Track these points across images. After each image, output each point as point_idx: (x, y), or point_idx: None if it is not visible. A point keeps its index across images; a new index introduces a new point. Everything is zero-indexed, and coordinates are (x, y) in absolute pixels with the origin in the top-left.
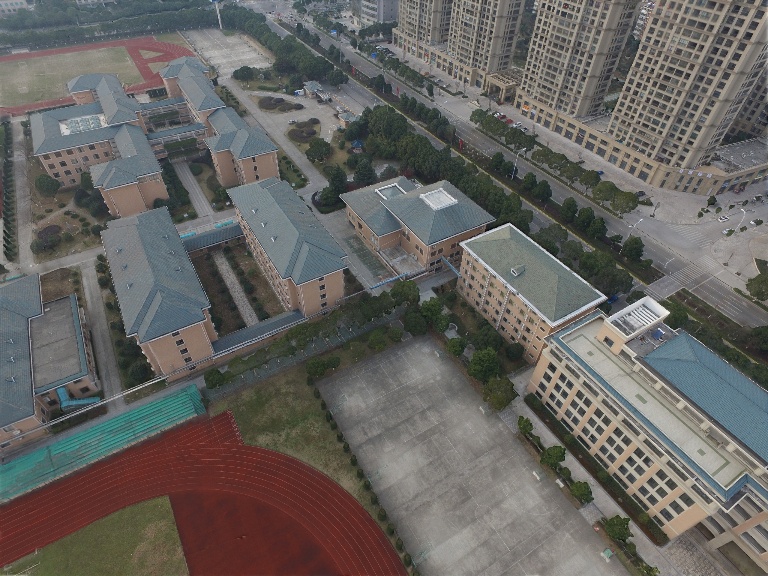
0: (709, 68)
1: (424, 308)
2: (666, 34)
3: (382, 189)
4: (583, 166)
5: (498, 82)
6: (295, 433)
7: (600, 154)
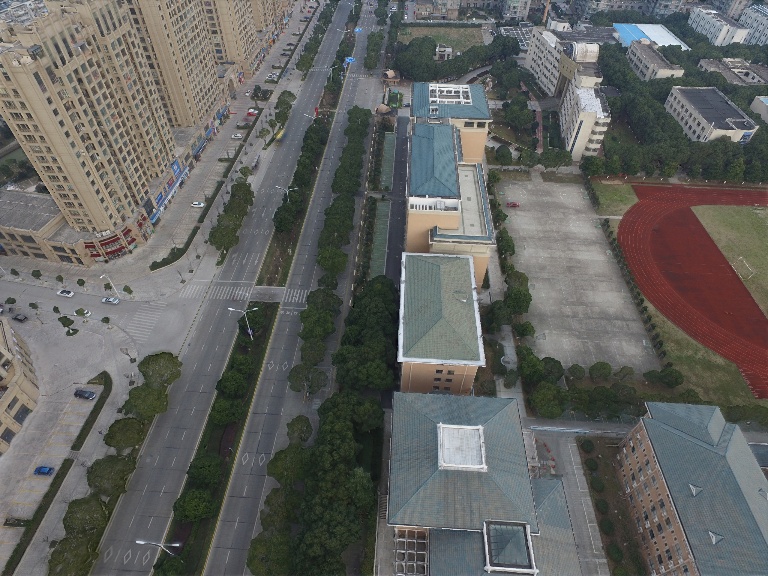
0: None
1: (542, 366)
2: None
3: (522, 570)
4: (28, 511)
5: None
6: (689, 352)
7: None
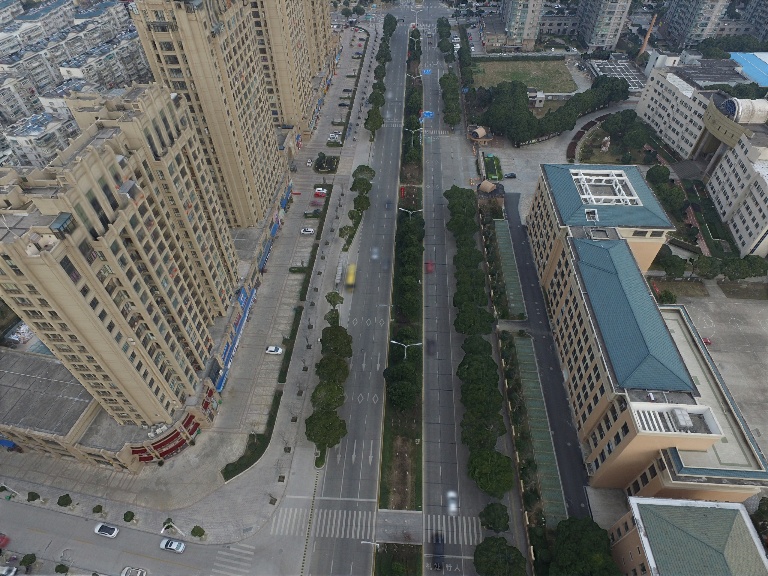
0: None
1: None
2: None
3: None
4: None
5: None
6: None
7: None
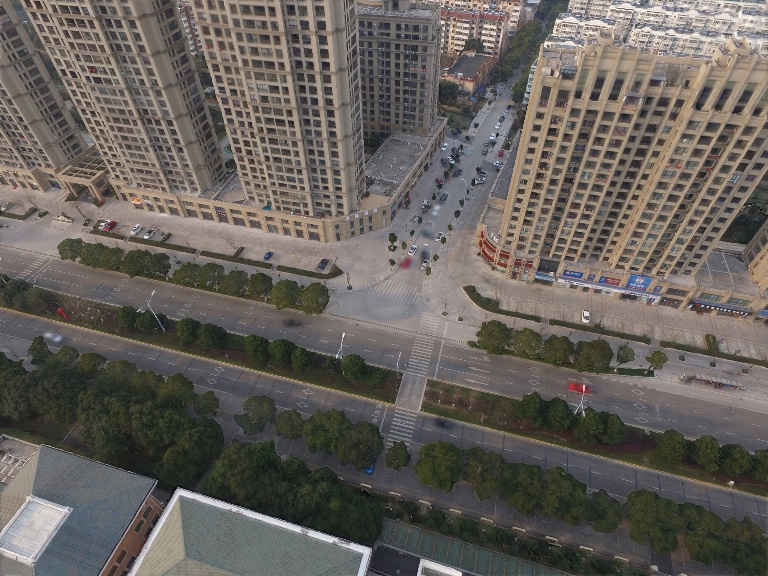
0: (308, 109)
1: None
2: (238, 81)
3: None
4: (245, 255)
5: (77, 180)
6: None
7: (256, 227)
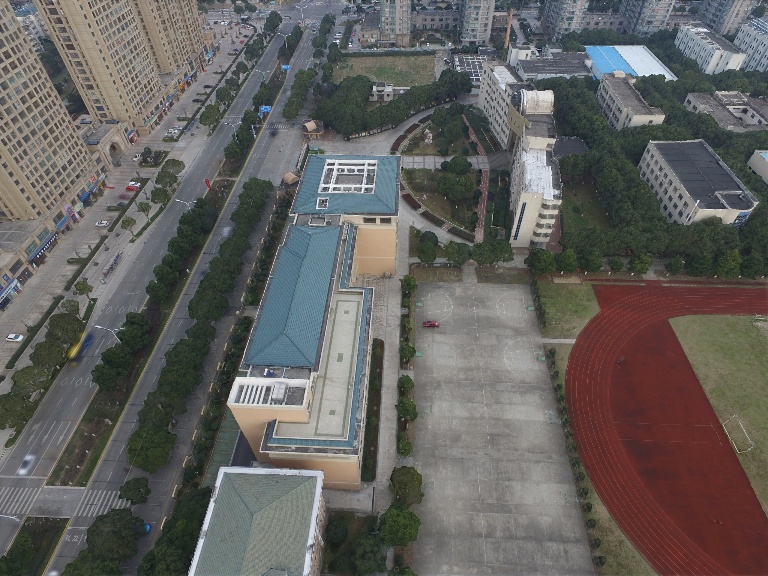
0: None
1: None
2: None
3: None
4: None
5: None
6: None
7: None
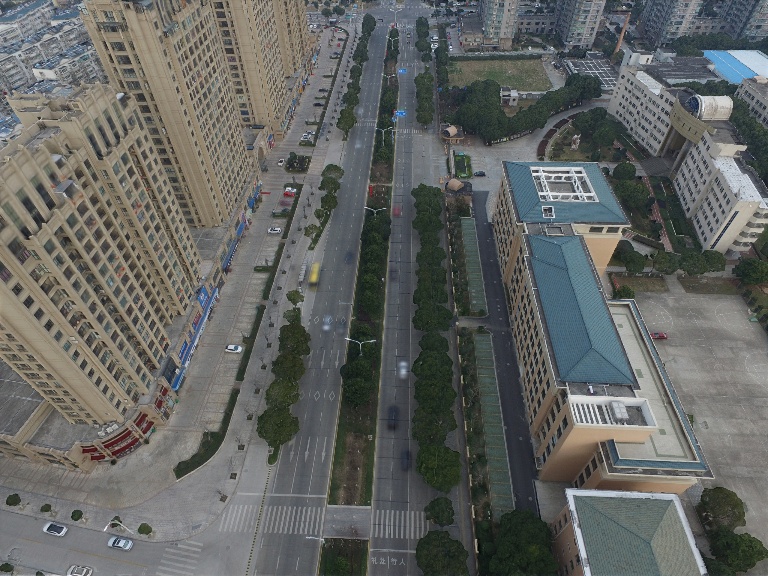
0: None
1: None
2: None
3: None
4: None
5: None
6: None
7: None
